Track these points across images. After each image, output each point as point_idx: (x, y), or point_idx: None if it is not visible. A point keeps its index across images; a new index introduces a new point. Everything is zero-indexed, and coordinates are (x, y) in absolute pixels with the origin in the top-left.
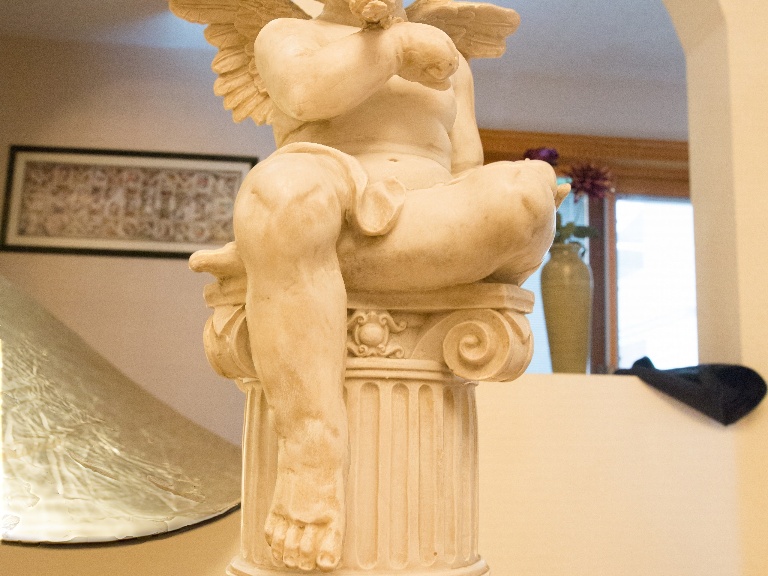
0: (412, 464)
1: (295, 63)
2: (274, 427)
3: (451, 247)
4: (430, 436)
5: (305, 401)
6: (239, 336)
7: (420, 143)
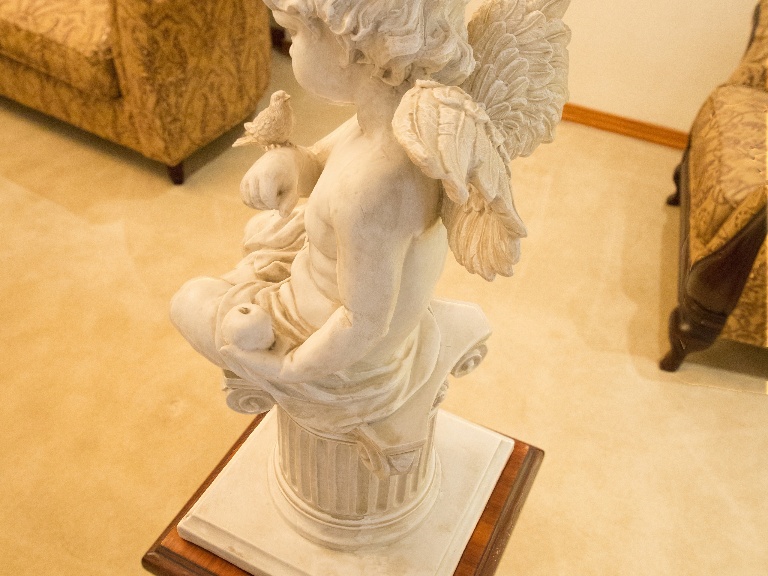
0: None
1: None
2: None
3: None
4: None
5: None
6: None
7: None
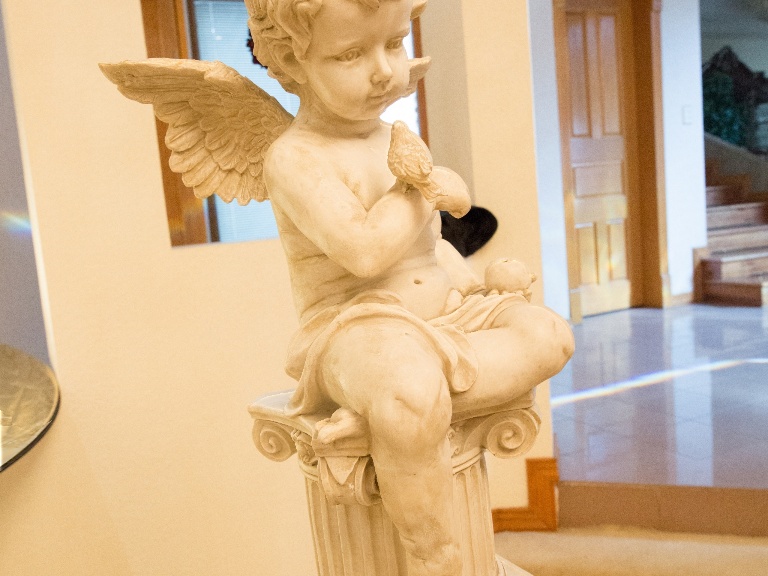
0: (473, 526)
1: (360, 234)
2: (412, 552)
3: (515, 390)
4: (478, 500)
5: (442, 535)
6: (363, 484)
7: (423, 252)
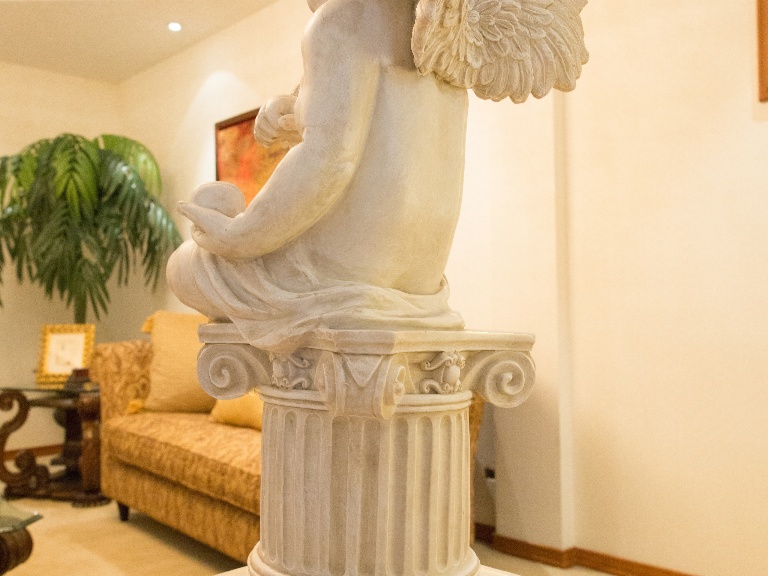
0: None
1: None
2: None
3: None
4: None
5: None
6: None
7: None
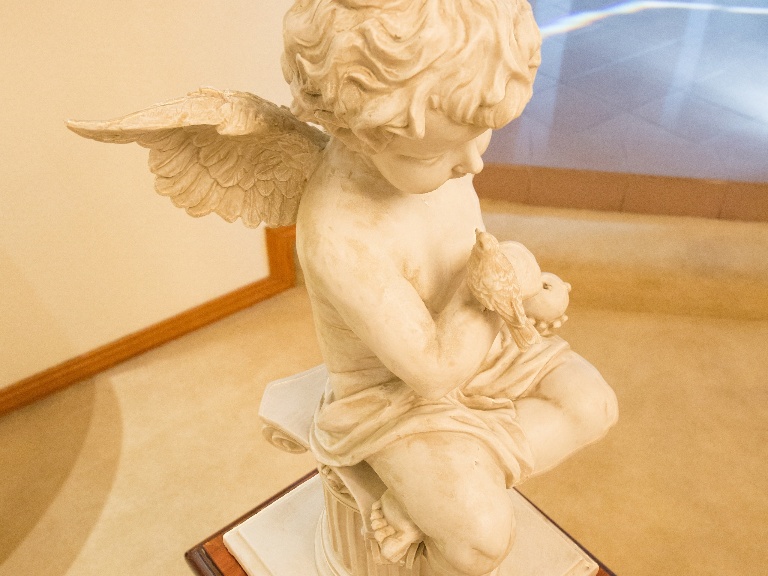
0: None
1: (435, 372)
2: None
3: None
4: None
5: None
6: None
7: None
